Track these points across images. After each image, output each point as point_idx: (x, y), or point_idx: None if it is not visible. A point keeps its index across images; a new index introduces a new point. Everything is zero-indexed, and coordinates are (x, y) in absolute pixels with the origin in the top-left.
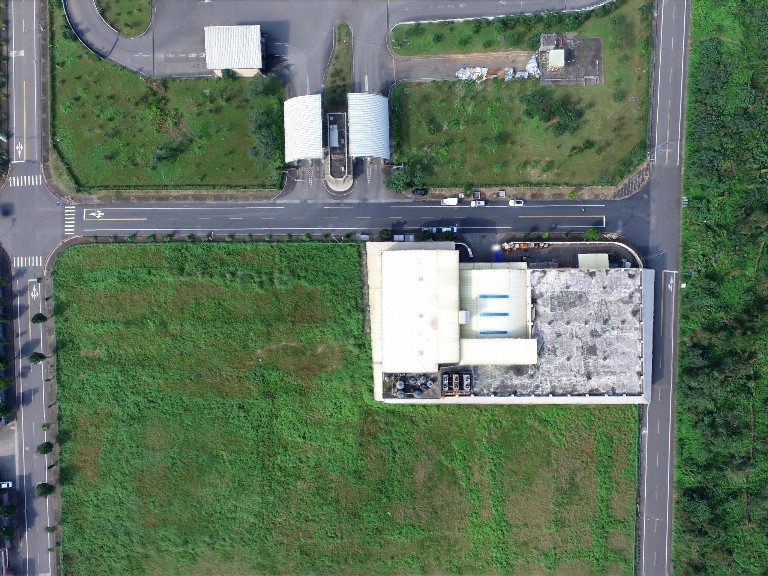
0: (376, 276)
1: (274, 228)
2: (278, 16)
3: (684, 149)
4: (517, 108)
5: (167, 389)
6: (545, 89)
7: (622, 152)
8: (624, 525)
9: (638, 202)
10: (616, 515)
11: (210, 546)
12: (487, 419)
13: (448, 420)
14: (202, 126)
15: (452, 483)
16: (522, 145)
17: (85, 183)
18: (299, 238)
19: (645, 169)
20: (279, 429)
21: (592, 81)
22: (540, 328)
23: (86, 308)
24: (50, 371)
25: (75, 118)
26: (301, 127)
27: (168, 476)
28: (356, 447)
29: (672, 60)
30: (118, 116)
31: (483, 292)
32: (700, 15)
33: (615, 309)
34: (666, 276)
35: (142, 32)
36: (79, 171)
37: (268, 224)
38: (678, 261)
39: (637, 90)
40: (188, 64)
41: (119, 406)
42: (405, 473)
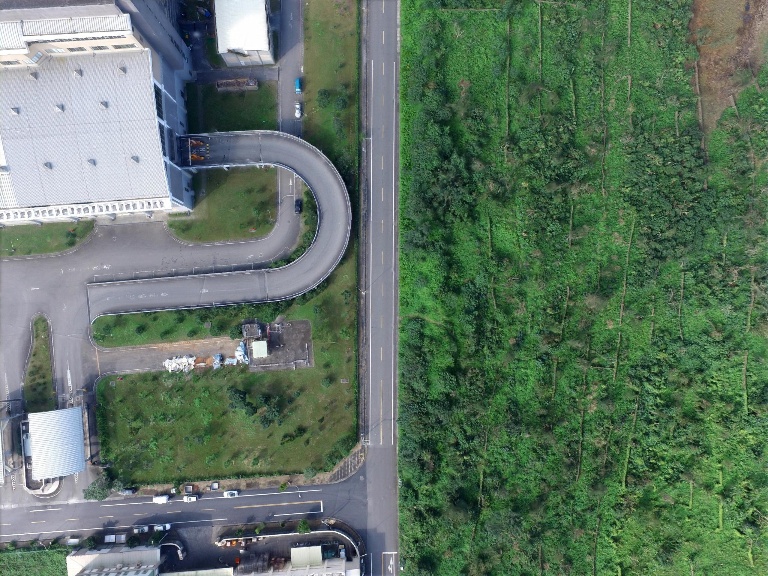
0: None
1: None
2: None
3: (397, 428)
4: (227, 397)
5: None
6: (255, 375)
7: (336, 435)
8: None
9: (354, 485)
10: None
11: None
12: None
13: None
14: None
15: None
16: (234, 435)
17: None
18: (4, 546)
19: (360, 451)
20: None
21: (302, 364)
22: None
23: None
24: None
25: None
26: None
27: None
28: None
29: (382, 338)
30: None
31: None
32: (407, 292)
33: None
34: (385, 558)
35: None
36: None
37: None
38: (397, 541)
39: (348, 371)
40: None
41: None
42: None
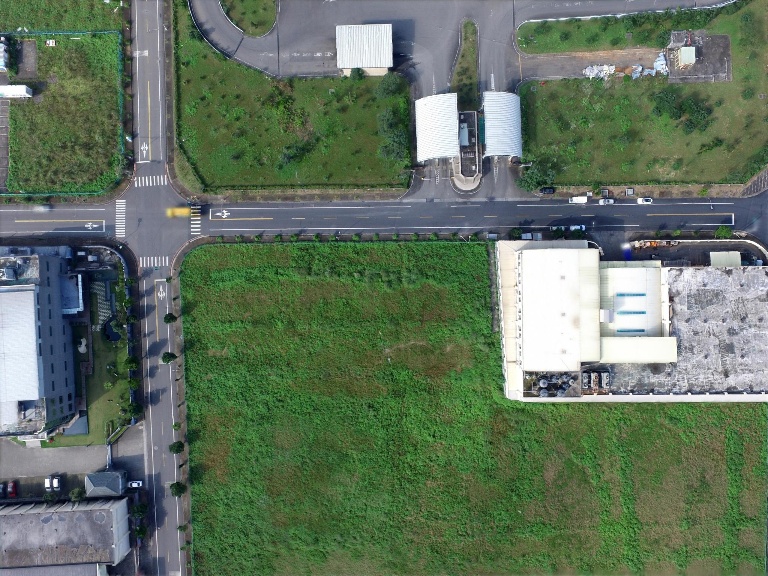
0: (509, 275)
1: (401, 227)
2: (403, 15)
3: None
4: (645, 106)
5: (296, 388)
6: (673, 87)
7: (751, 149)
8: (755, 523)
9: (767, 200)
10: (747, 513)
11: (341, 544)
12: (617, 417)
13: (577, 418)
14: (328, 125)
15: (582, 481)
16: (650, 143)
17: (211, 183)
18: (426, 237)
19: None
20: (409, 428)
21: (720, 78)
22: (677, 326)
23: (213, 308)
24: (178, 371)
25: (200, 118)
26: (436, 126)
27: (298, 475)
28: (487, 446)
29: None
30: (244, 116)
31: (620, 290)
32: None
33: (752, 307)
34: None
35: (267, 31)
36: (205, 171)
37: (395, 223)
38: None
39: (766, 87)
40: (313, 63)
41: (248, 405)
42: (535, 471)
